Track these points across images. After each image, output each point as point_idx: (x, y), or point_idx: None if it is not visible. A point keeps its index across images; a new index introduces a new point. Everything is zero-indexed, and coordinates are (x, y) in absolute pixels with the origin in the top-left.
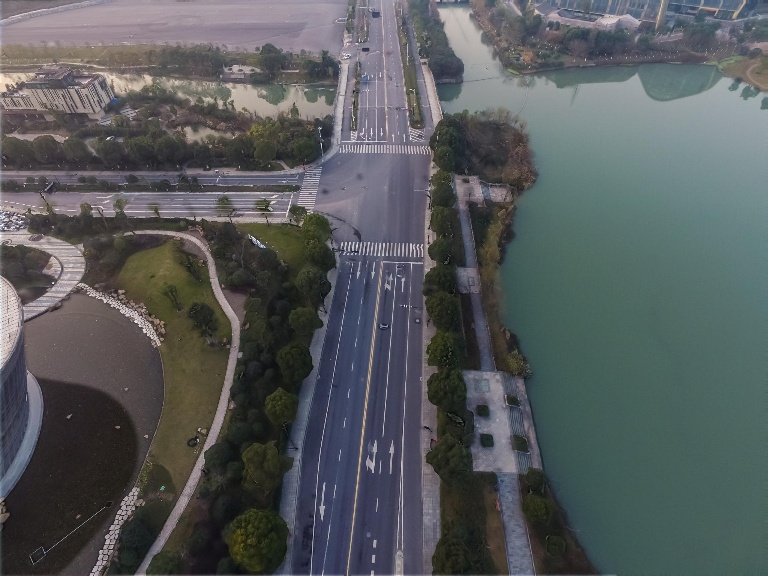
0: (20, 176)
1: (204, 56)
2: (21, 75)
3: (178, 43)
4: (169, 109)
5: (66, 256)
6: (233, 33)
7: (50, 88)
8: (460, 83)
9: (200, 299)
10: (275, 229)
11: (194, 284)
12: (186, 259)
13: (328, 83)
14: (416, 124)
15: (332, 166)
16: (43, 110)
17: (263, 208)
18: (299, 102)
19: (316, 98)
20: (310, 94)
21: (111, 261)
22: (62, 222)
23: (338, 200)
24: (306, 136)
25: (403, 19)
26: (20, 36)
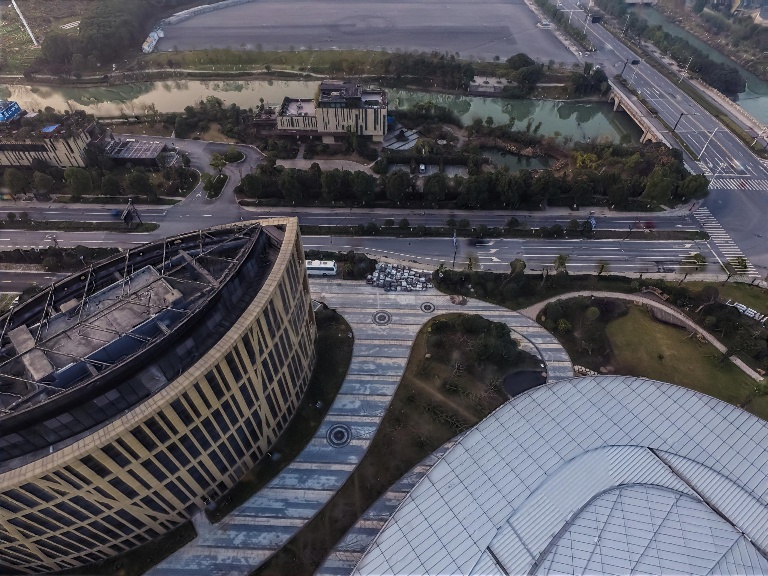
0: (359, 215)
1: (454, 67)
2: (219, 82)
3: (398, 49)
4: (449, 129)
5: (521, 326)
6: (441, 38)
7: (346, 107)
8: (736, 101)
9: (750, 390)
10: (736, 290)
11: (723, 368)
12: (677, 332)
13: (596, 99)
14: (762, 153)
15: (717, 206)
16: (325, 131)
17: (690, 261)
18: (551, 119)
19: (570, 114)
20: (562, 110)
21: (593, 336)
22: (493, 282)
23: (767, 251)
24: (679, 170)
25: (627, 25)
26: (201, 37)
